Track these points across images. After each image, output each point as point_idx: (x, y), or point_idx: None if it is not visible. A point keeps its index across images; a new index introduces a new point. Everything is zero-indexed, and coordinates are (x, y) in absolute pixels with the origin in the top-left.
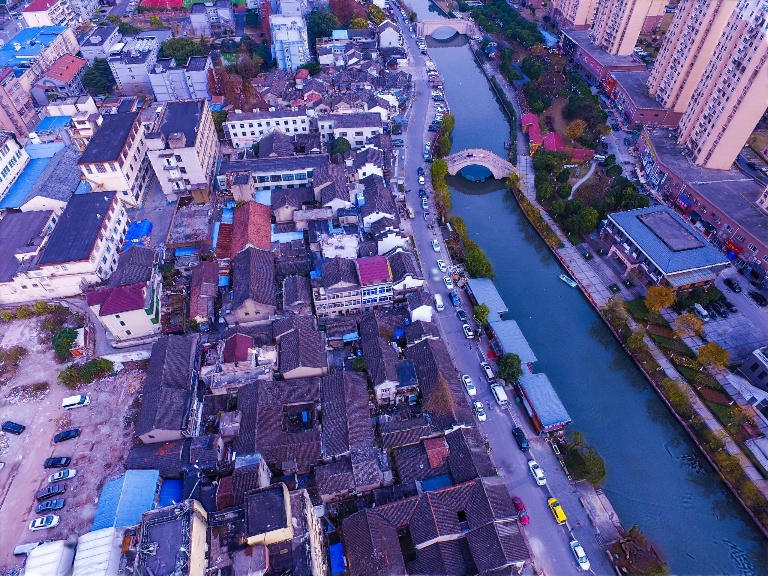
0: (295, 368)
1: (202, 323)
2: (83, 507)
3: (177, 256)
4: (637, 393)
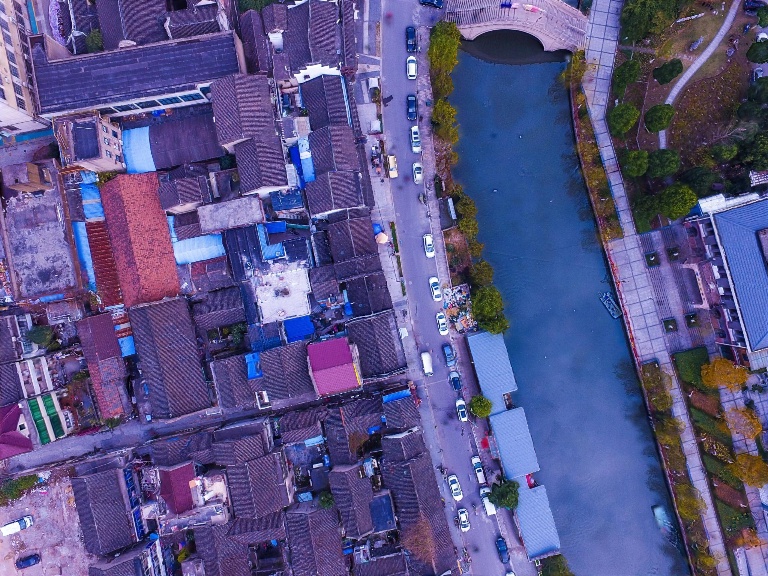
0: None
1: (121, 415)
2: None
3: (44, 301)
4: (645, 457)
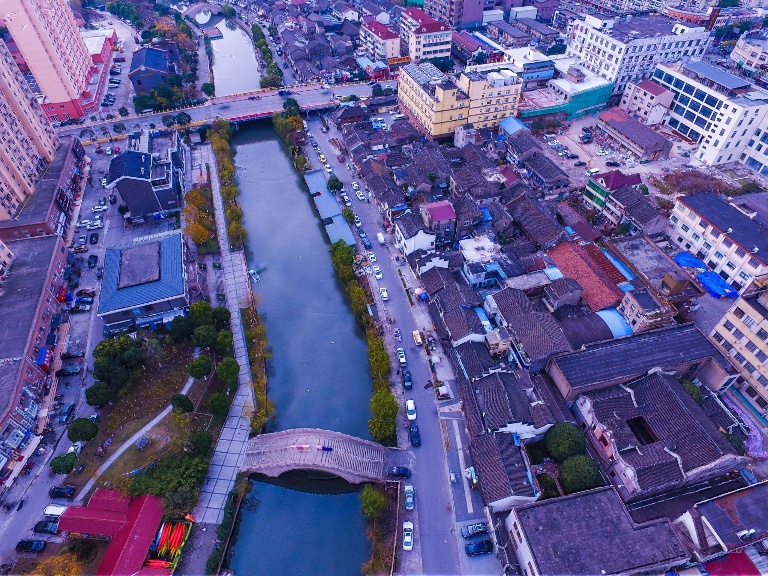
0: (469, 168)
1: None
2: (543, 148)
3: None
4: None
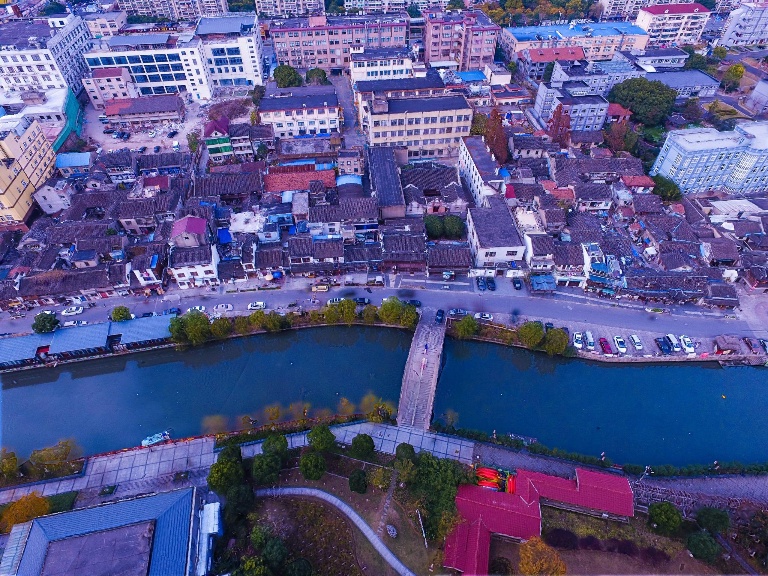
0: None
1: None
2: None
3: None
4: None
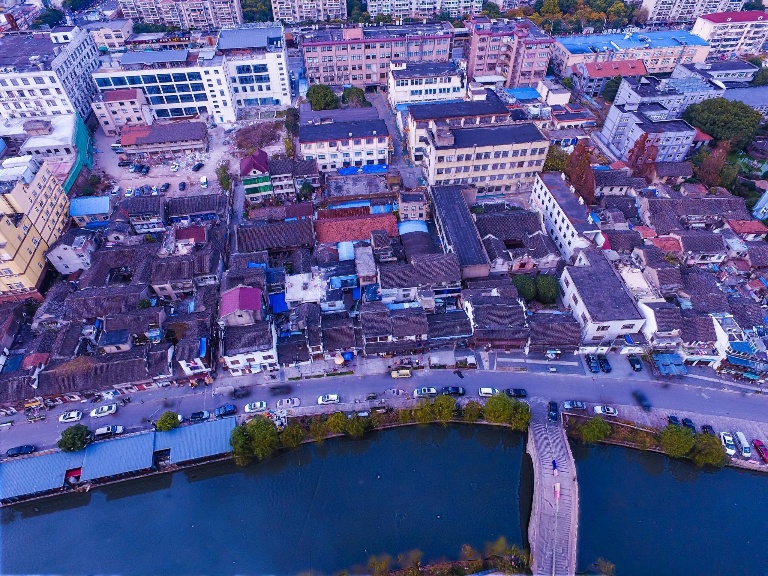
0: None
1: None
2: None
3: None
4: None
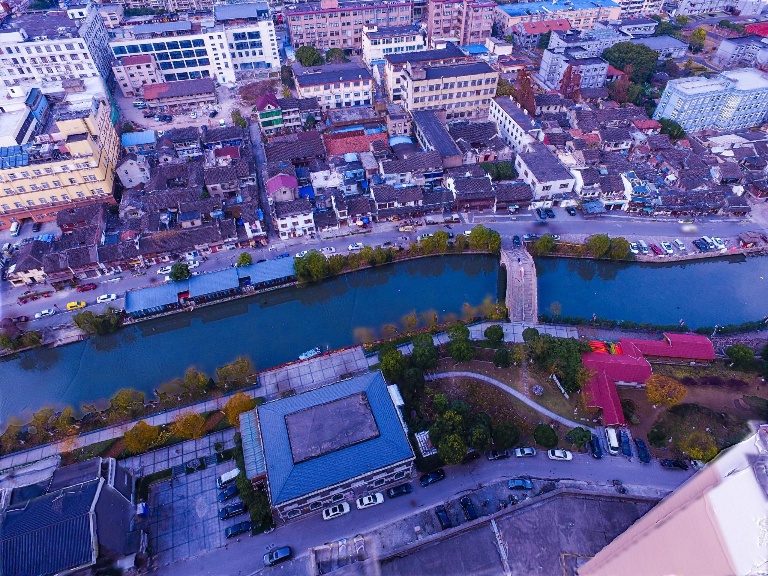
0: None
1: None
2: None
3: None
4: None
